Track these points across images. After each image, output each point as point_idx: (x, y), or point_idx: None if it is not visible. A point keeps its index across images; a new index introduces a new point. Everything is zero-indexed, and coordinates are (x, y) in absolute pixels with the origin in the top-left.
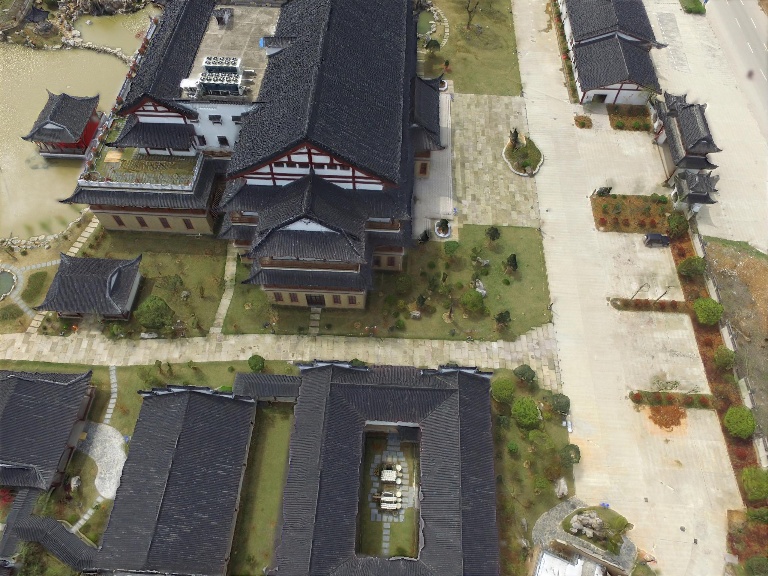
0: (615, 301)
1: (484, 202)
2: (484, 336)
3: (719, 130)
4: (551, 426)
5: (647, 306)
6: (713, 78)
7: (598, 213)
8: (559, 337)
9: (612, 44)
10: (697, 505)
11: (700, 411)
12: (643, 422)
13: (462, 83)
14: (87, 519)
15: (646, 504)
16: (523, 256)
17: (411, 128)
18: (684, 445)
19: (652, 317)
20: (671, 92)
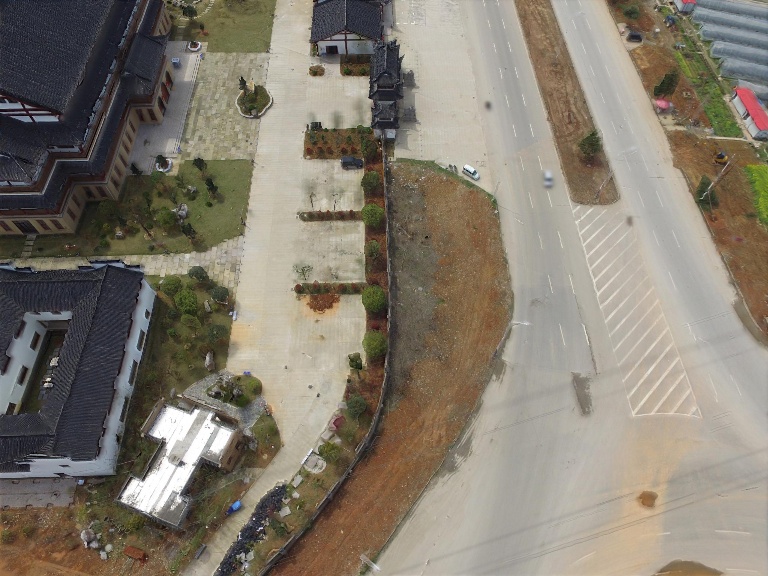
0: (303, 214)
1: (209, 141)
2: (180, 249)
3: (436, 72)
4: (219, 316)
5: (328, 216)
6: (444, 29)
7: (308, 145)
8: (246, 246)
9: (341, 1)
10: (328, 368)
11: (352, 296)
12: (301, 308)
13: (216, 44)
14: None
15: (285, 370)
16: (231, 183)
17: (125, 76)
18: (330, 323)
19: (332, 225)
20: (403, 42)
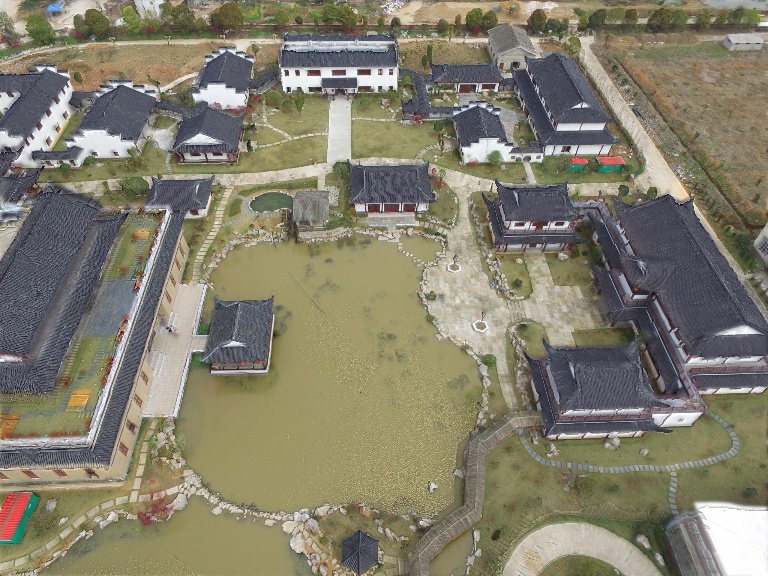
0: None
1: None
2: None
3: None
4: None
5: None
6: None
7: None
8: None
9: None
10: None
11: None
12: None
13: None
14: (175, 123)
15: None
16: None
17: None
18: None
19: None
20: None
